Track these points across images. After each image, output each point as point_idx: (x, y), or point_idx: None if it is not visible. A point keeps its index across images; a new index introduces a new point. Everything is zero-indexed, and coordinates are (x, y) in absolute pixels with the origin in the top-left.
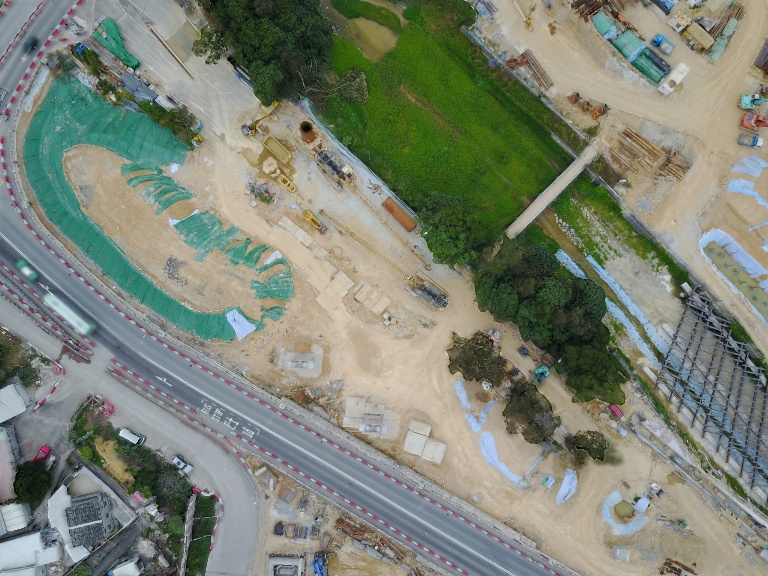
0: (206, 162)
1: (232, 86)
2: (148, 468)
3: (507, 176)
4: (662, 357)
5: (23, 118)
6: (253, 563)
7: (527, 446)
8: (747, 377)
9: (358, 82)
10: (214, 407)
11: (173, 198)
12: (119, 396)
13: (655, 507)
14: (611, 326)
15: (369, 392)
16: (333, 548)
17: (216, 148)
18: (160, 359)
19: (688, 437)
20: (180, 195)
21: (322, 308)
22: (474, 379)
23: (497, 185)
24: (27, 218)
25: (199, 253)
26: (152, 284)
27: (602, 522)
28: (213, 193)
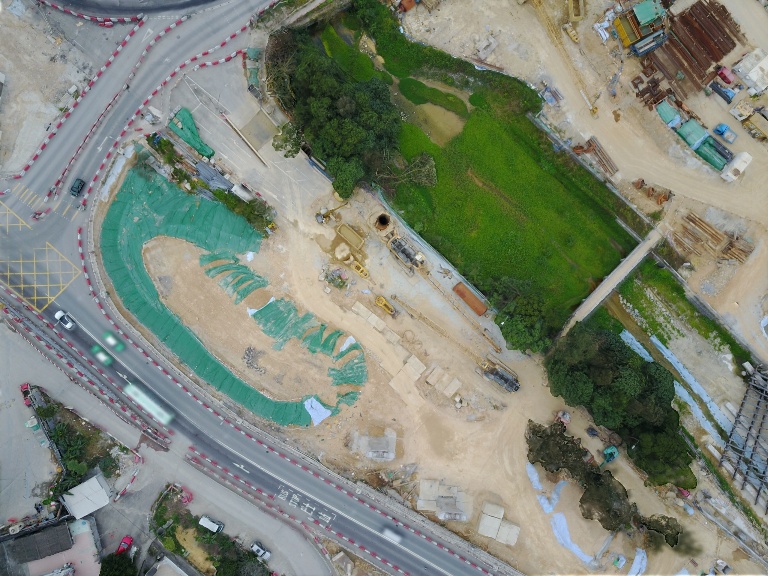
0: (280, 249)
1: (305, 174)
2: (230, 558)
3: (572, 258)
4: (725, 434)
5: (100, 208)
6: None
7: (597, 526)
8: None
9: (428, 168)
10: (291, 493)
11: (250, 287)
12: (197, 484)
13: None
14: (675, 404)
15: (442, 475)
16: None
17: (290, 235)
18: (237, 446)
19: (751, 513)
20: (256, 283)
21: (395, 392)
22: None
23: (563, 267)
24: (105, 308)
25: (277, 342)
26: (231, 373)
27: None
28: (287, 280)
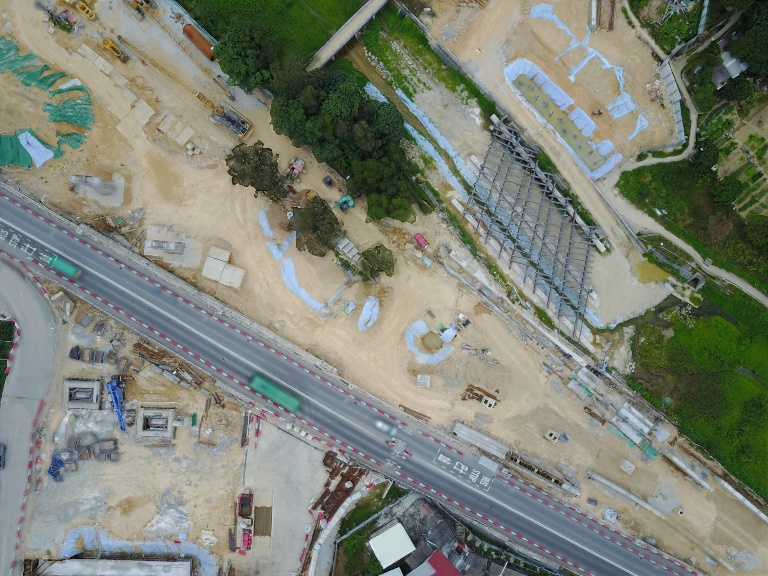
0: None
1: None
2: None
3: (315, 9)
4: None
5: None
6: (49, 386)
7: (330, 274)
8: (554, 208)
9: None
10: (11, 233)
11: None
12: None
13: (461, 337)
14: (420, 159)
15: (170, 220)
16: (131, 373)
17: None
18: None
19: (497, 269)
20: None
21: (122, 136)
22: (279, 210)
23: (304, 17)
24: None
25: None
26: None
27: (406, 350)
28: (11, 20)
